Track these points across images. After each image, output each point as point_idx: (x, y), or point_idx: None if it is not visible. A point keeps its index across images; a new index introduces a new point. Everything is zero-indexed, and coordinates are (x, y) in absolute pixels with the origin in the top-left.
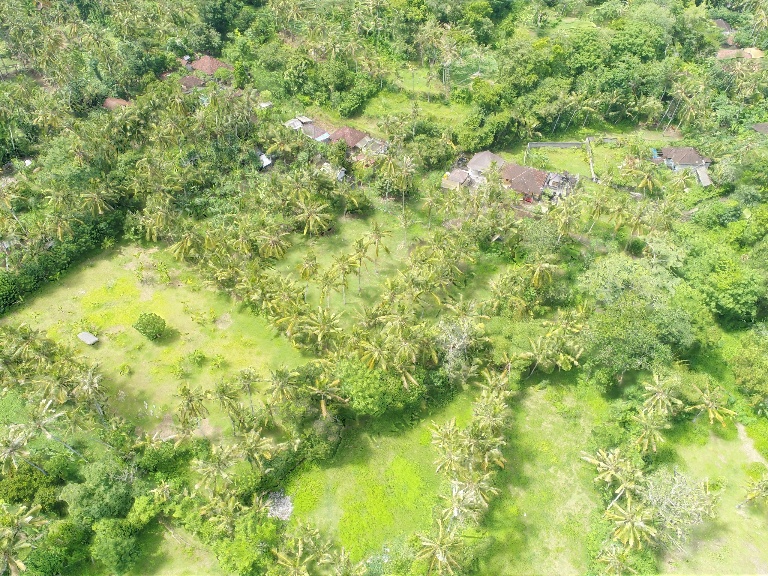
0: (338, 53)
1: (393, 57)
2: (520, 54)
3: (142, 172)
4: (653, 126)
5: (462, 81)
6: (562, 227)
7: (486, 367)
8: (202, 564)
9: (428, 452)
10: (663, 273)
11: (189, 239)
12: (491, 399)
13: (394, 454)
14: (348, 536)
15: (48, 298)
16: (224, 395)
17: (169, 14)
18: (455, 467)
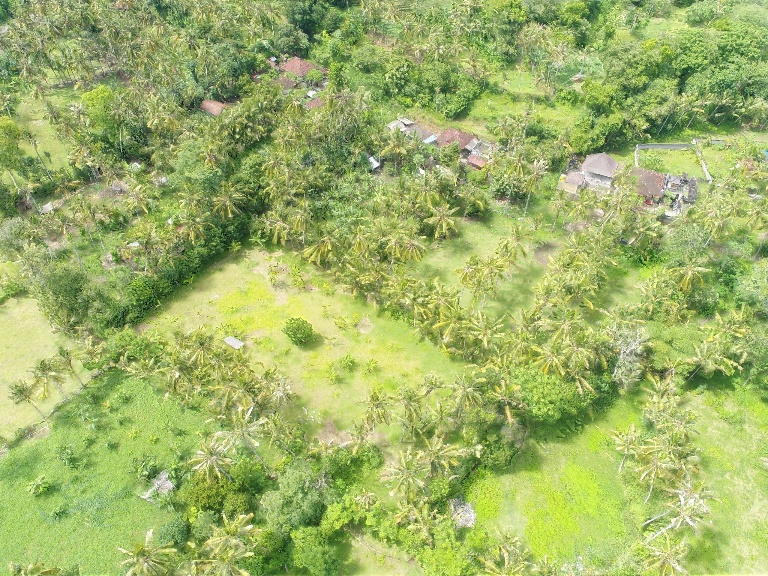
0: (441, 55)
1: (493, 58)
2: (632, 55)
3: (280, 175)
4: (756, 127)
5: (565, 82)
6: (716, 230)
7: (648, 372)
8: (396, 572)
9: (599, 458)
10: None
11: (329, 243)
12: (662, 405)
13: (565, 460)
14: (538, 544)
15: (183, 302)
16: (411, 401)
17: (258, 16)
18: (661, 474)
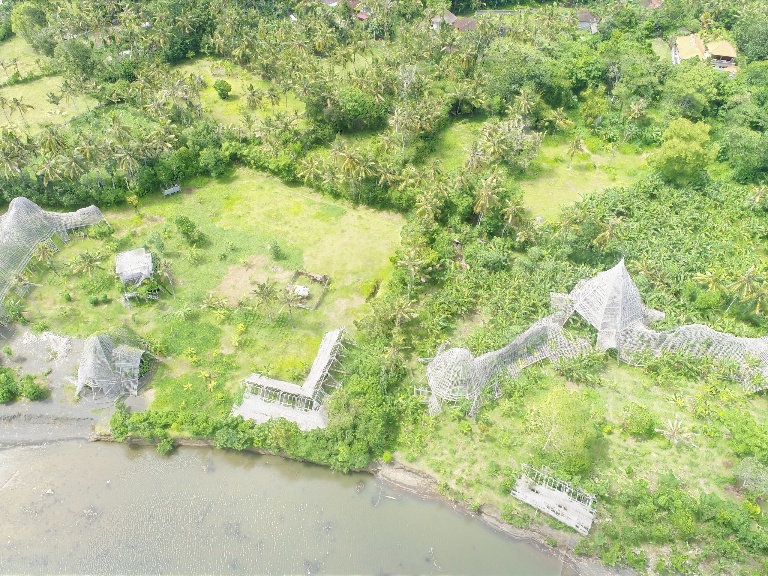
0: None
1: None
2: None
3: None
4: (569, 5)
5: None
6: (480, 27)
7: None
8: (259, 180)
9: None
10: (540, 53)
11: (246, 41)
12: None
13: None
14: None
15: None
16: (272, 92)
17: None
18: None
